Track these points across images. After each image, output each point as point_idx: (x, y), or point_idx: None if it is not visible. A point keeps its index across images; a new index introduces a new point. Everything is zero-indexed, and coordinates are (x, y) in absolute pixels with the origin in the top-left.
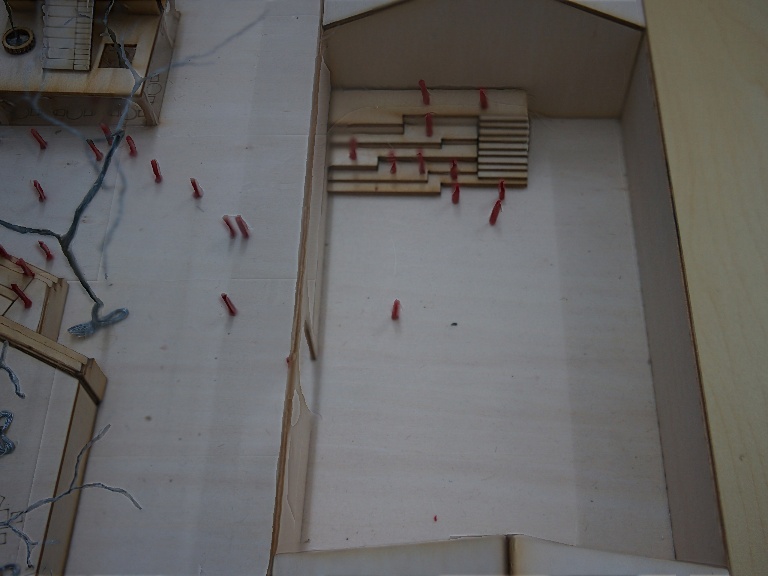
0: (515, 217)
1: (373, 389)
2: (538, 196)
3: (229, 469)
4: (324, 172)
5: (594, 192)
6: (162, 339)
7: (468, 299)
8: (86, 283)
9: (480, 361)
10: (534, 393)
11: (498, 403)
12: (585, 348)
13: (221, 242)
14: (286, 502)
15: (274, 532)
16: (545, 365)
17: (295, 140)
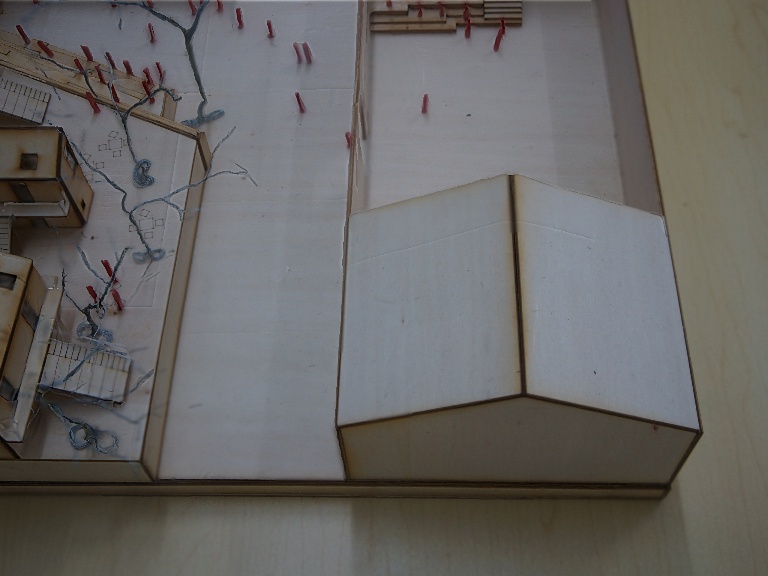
0: (513, 45)
1: (409, 157)
2: (530, 32)
3: (305, 208)
4: (367, 18)
5: (573, 28)
6: (251, 129)
7: (479, 99)
8: (199, 76)
9: (488, 138)
10: (529, 156)
11: (502, 163)
12: (567, 128)
13: (291, 66)
14: (355, 187)
15: (348, 205)
16: (537, 139)
17: None
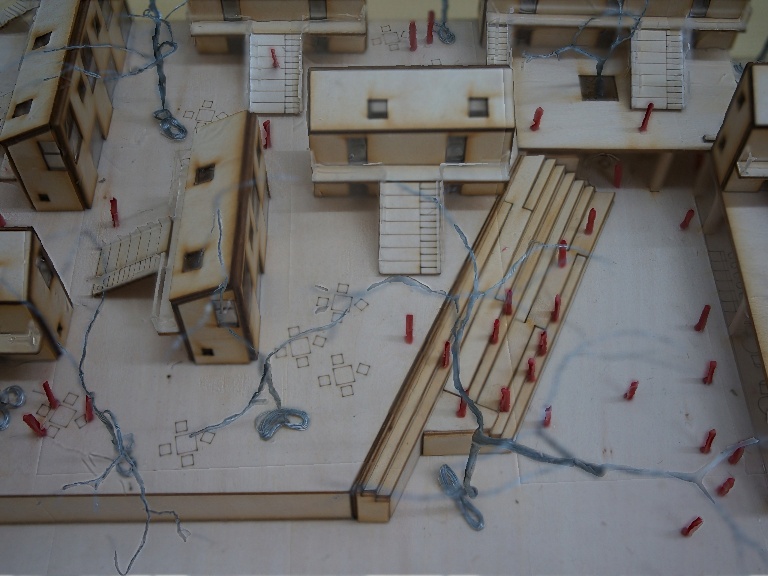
0: None
1: None
2: None
3: None
4: None
5: None
6: None
7: None
8: (467, 472)
9: None
10: None
11: None
12: None
13: None
14: None
15: None
16: None
17: None
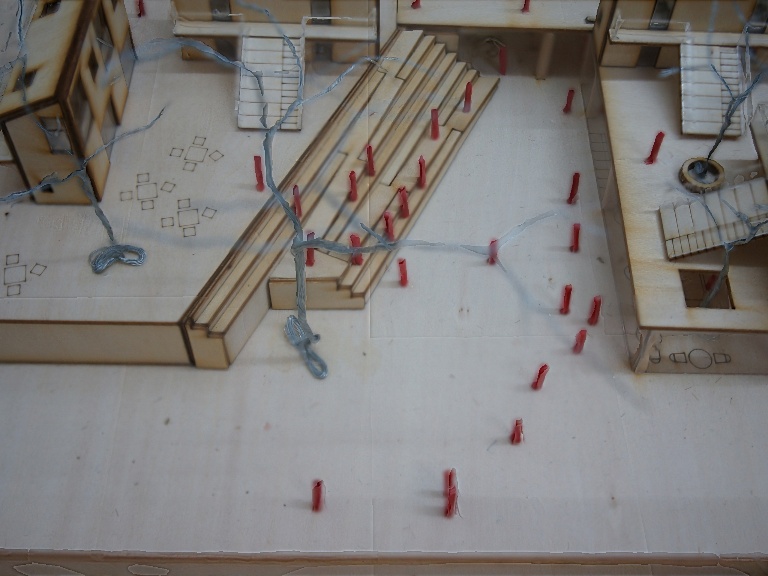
0: None
1: None
2: None
3: (81, 526)
4: None
5: None
6: (280, 423)
7: None
8: (298, 301)
9: None
10: None
11: None
12: None
13: (436, 479)
14: None
15: None
16: None
17: (640, 571)
